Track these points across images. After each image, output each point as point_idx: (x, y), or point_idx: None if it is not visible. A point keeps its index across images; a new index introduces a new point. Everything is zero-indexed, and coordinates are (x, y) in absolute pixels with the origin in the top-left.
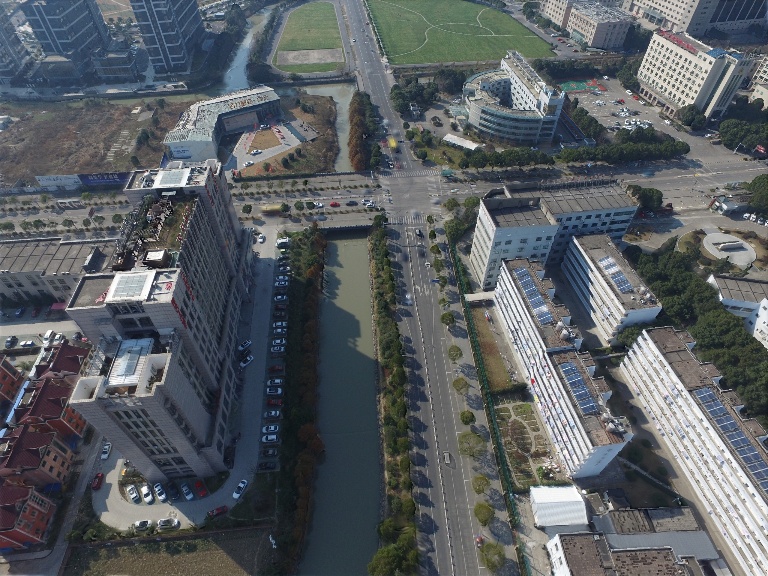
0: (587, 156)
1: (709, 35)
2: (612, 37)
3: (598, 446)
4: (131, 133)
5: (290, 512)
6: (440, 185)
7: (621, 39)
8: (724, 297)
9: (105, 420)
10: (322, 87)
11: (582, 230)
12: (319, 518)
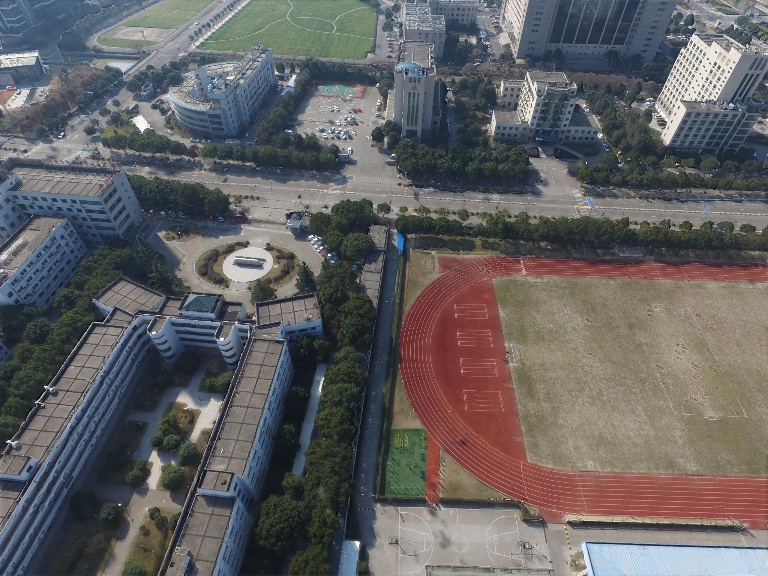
0: (220, 153)
1: (553, 57)
2: None
3: None
4: None
5: None
6: None
7: (439, 49)
8: (100, 299)
9: None
10: (123, 62)
11: (62, 213)
12: None
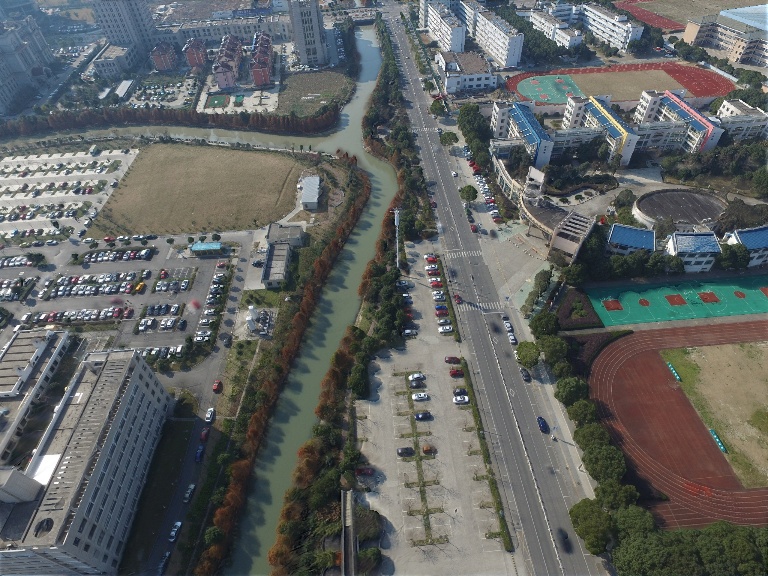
0: None
1: None
2: None
3: (453, 28)
4: (245, 5)
5: (353, 62)
6: (407, 8)
7: None
8: None
9: (298, 14)
10: None
11: None
12: (362, 76)
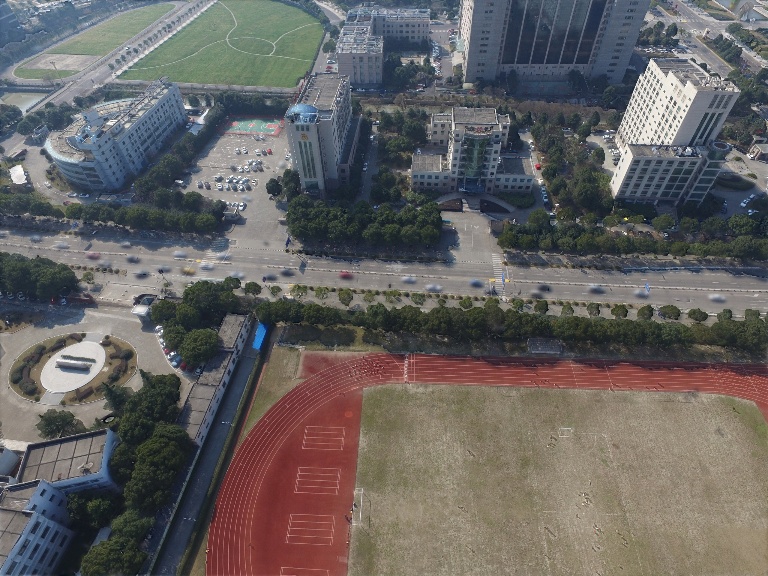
0: (85, 215)
1: (507, 79)
2: (363, 71)
3: None
4: None
5: None
6: None
7: (377, 74)
8: None
9: None
10: (37, 95)
11: None
12: None
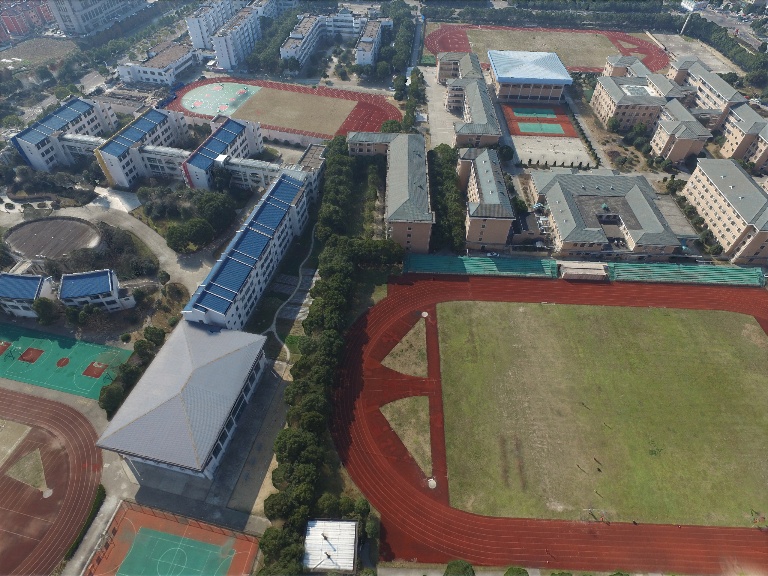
0: None
1: None
2: None
3: None
4: None
5: None
6: None
7: None
8: None
9: None
10: None
11: None
12: None
